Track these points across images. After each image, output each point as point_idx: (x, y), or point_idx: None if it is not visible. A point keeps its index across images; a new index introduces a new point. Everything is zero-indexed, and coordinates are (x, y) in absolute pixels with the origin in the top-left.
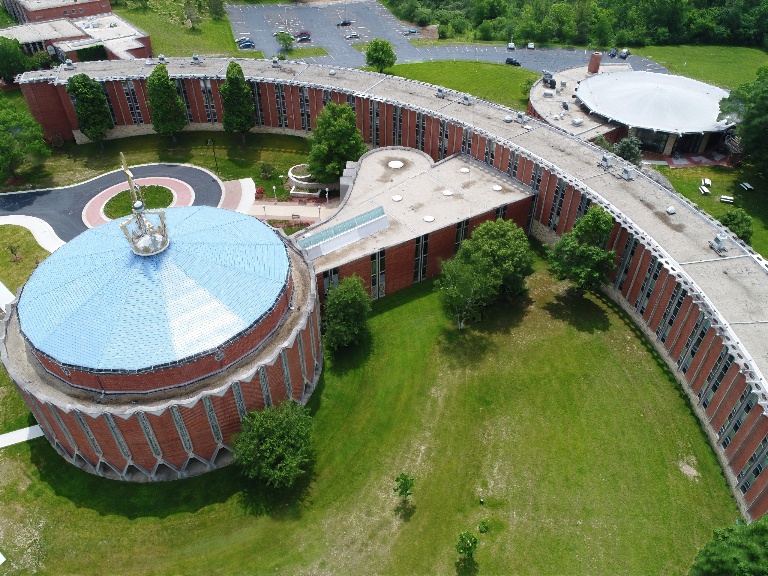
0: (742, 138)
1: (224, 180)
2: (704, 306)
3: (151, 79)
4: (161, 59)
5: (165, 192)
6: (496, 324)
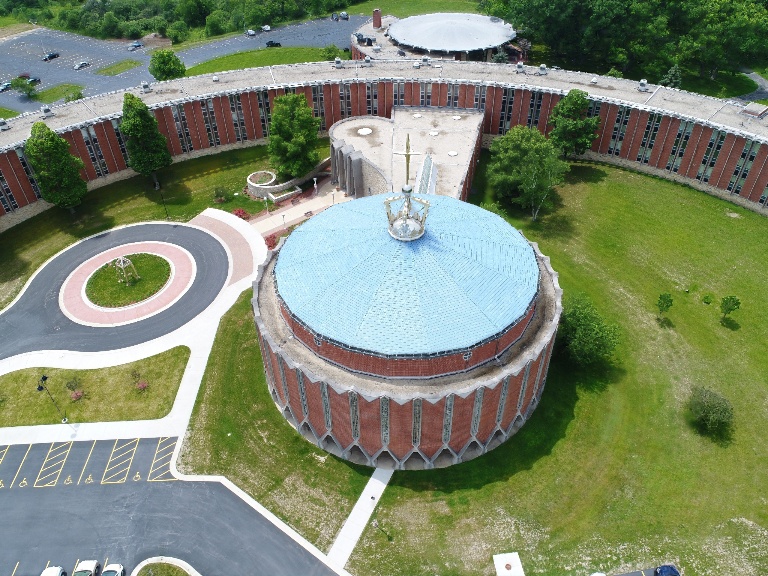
0: (546, 34)
1: (186, 221)
2: (685, 118)
3: (40, 142)
4: (2, 124)
5: (142, 257)
6: None
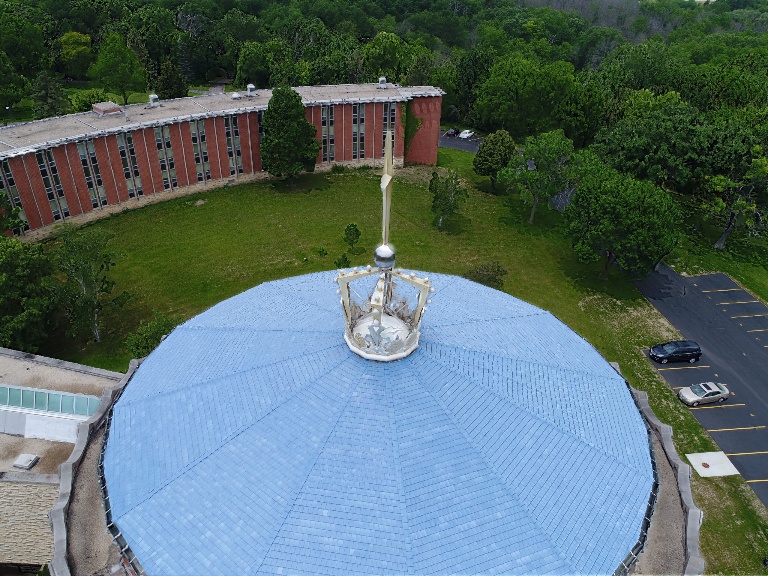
0: None
1: None
2: None
3: None
4: None
5: None
6: None
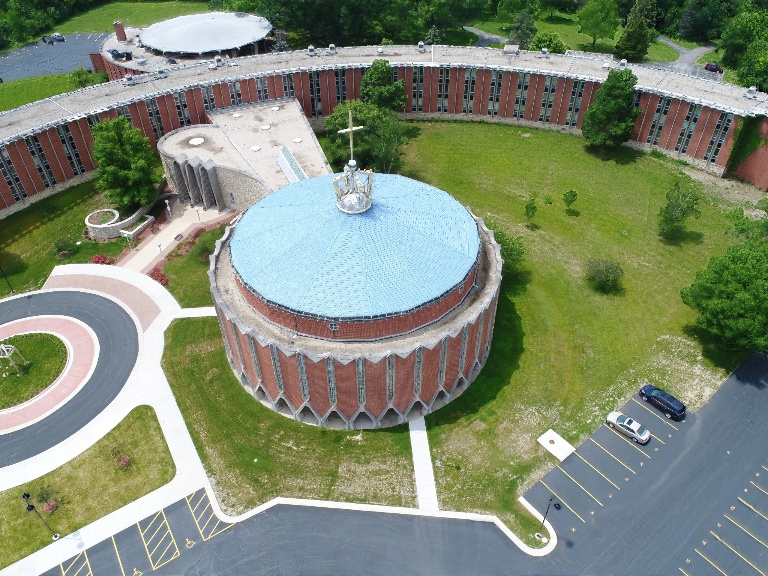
0: (304, 20)
1: (38, 288)
2: None
3: None
4: None
5: (14, 341)
6: (392, 166)
